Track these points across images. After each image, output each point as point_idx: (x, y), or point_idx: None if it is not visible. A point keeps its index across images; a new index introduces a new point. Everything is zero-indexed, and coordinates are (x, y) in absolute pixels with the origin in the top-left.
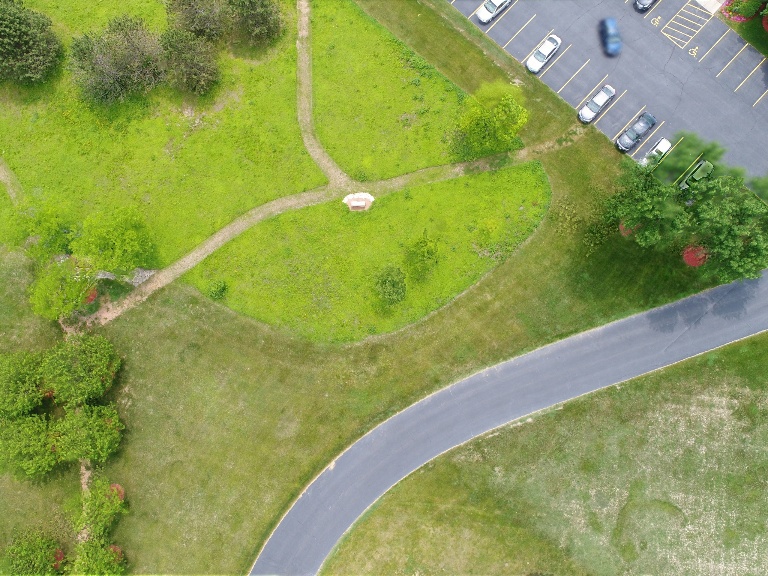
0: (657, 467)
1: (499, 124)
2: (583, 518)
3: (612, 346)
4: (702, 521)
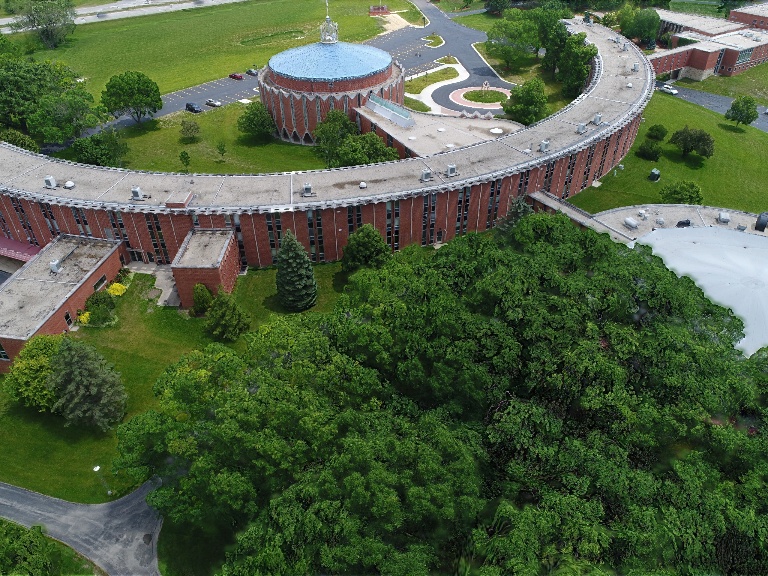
0: (697, 7)
1: None
2: (671, 6)
3: None
4: (700, 11)
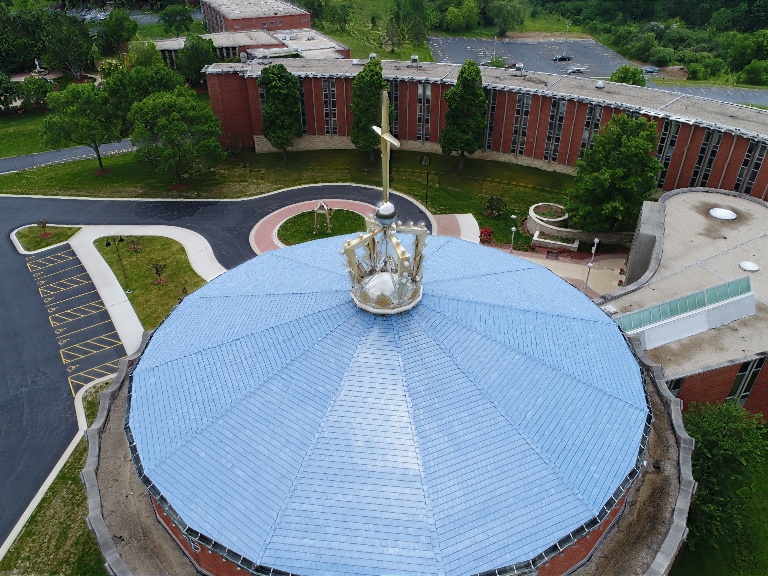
0: None
1: (22, 5)
2: None
3: None
4: None
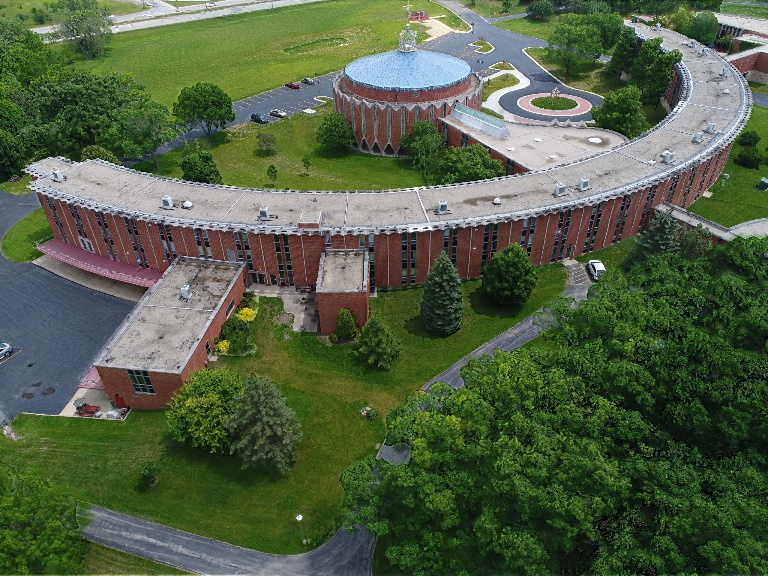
0: None
1: None
2: None
3: (744, 4)
4: None
